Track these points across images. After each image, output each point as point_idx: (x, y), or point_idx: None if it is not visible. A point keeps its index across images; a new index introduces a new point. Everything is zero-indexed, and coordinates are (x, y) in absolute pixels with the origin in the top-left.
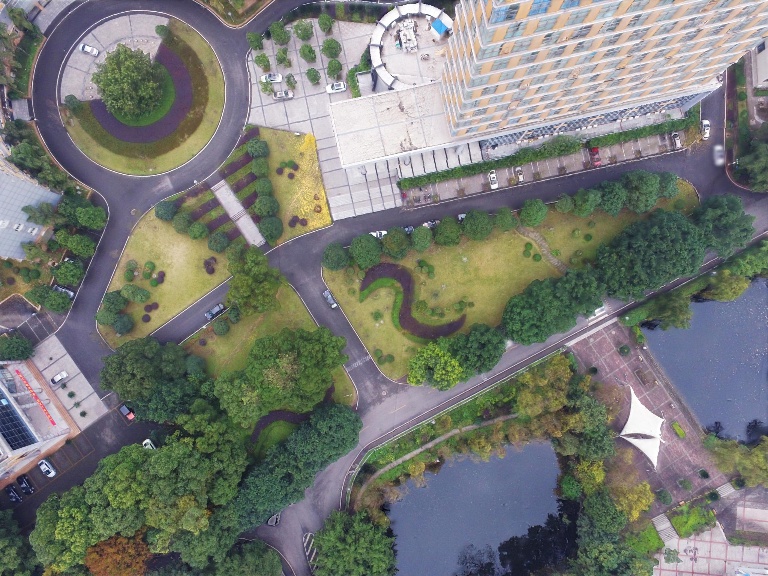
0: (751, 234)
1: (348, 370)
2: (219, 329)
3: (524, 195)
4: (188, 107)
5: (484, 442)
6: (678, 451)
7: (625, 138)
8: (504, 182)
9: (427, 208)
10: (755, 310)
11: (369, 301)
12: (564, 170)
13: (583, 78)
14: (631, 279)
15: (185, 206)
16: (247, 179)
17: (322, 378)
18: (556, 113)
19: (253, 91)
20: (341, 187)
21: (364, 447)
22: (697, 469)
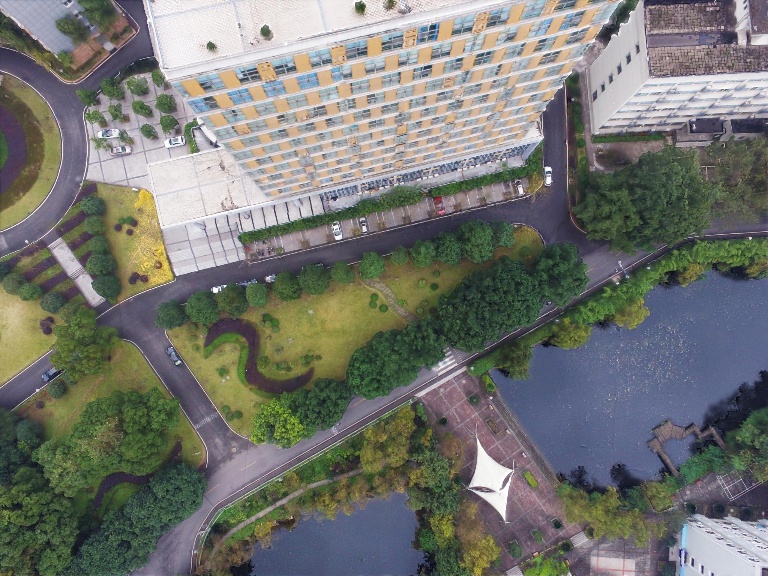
0: (585, 283)
1: (196, 427)
2: (52, 392)
3: (369, 245)
4: (23, 165)
5: (328, 500)
6: (531, 501)
7: (467, 187)
8: (349, 233)
9: (271, 261)
10: (606, 354)
11: (214, 357)
12: (408, 219)
13: (367, 144)
14: (468, 331)
15: (20, 265)
16: (84, 237)
17: (148, 443)
18: (371, 171)
19: (91, 147)
20: (181, 242)
21: (214, 506)
22: (550, 519)
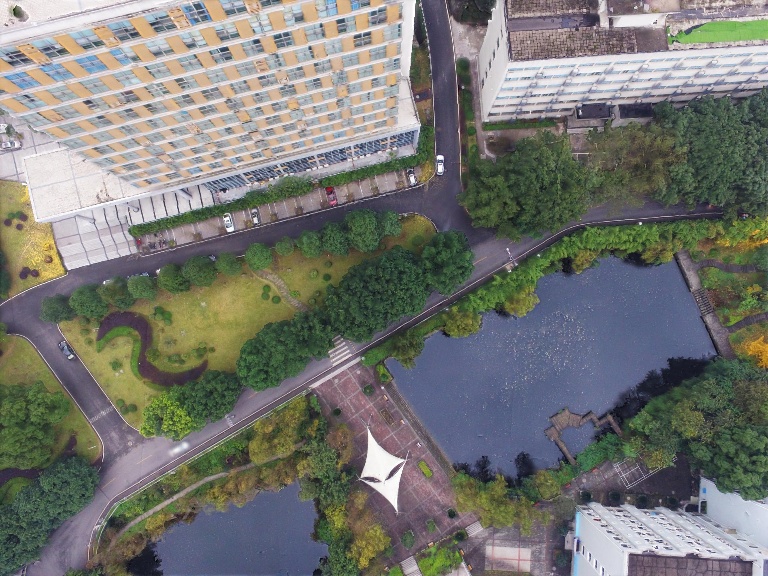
0: (470, 271)
1: (91, 421)
2: None
3: (262, 237)
4: None
5: (218, 492)
6: (426, 491)
7: (357, 177)
8: (241, 224)
9: (163, 254)
10: (503, 343)
11: (107, 350)
12: (300, 210)
13: (214, 132)
14: (354, 320)
15: None
16: None
17: (27, 437)
18: (241, 160)
19: None
20: (71, 236)
21: (111, 500)
22: (446, 508)
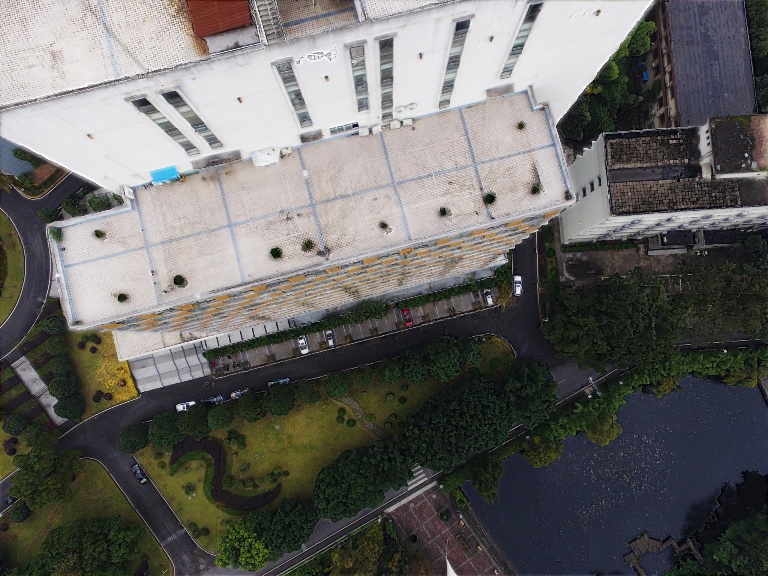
0: (554, 404)
1: (163, 544)
2: (14, 518)
3: (336, 358)
4: None
5: None
6: None
7: (434, 299)
8: (315, 346)
9: (237, 375)
10: (580, 465)
11: (180, 474)
12: (376, 332)
13: None
14: (435, 453)
15: None
16: (47, 356)
17: None
18: None
19: None
20: (145, 359)
21: None
22: None
